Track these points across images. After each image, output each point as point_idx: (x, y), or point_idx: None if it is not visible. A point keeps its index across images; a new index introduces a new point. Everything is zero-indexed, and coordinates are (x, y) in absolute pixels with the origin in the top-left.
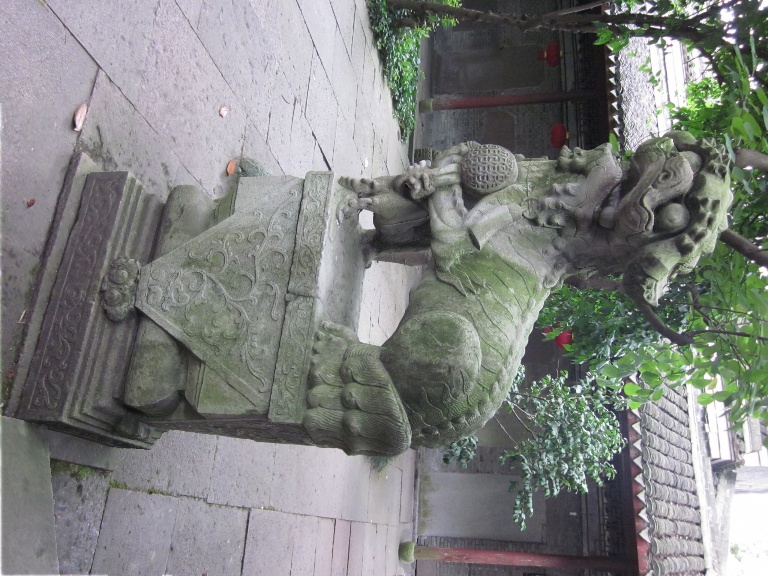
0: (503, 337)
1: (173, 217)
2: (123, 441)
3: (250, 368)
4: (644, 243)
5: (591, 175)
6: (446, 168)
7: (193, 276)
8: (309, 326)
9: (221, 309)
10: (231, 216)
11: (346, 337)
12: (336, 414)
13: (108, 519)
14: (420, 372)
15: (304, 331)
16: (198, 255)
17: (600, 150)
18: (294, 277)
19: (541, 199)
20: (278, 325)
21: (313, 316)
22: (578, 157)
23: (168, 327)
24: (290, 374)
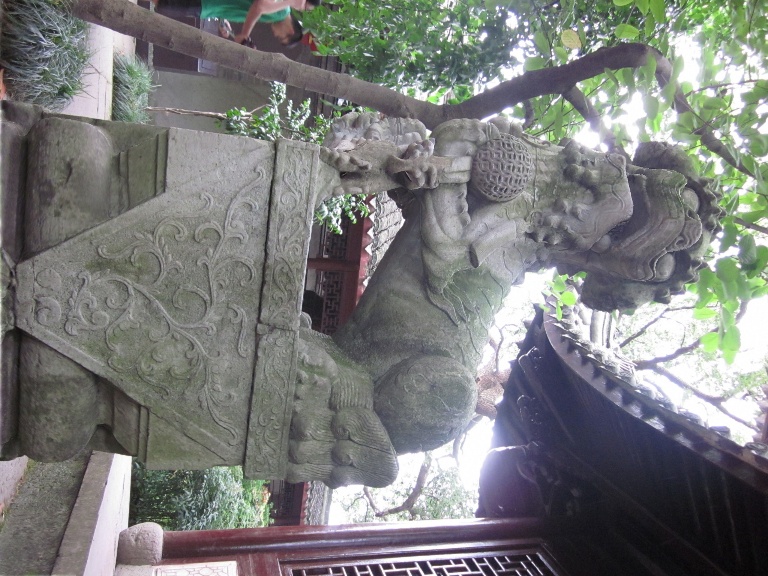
0: (479, 360)
1: (55, 179)
2: None
3: (215, 417)
4: (626, 281)
5: (606, 205)
6: (459, 163)
7: (110, 286)
8: (290, 368)
9: (163, 338)
10: (163, 196)
11: (329, 374)
12: (325, 468)
13: None
14: (422, 433)
15: (284, 374)
16: (114, 254)
17: (617, 169)
18: (268, 303)
19: (544, 211)
20: (248, 364)
21: (295, 356)
22: (591, 167)
23: (81, 359)
24: (269, 426)
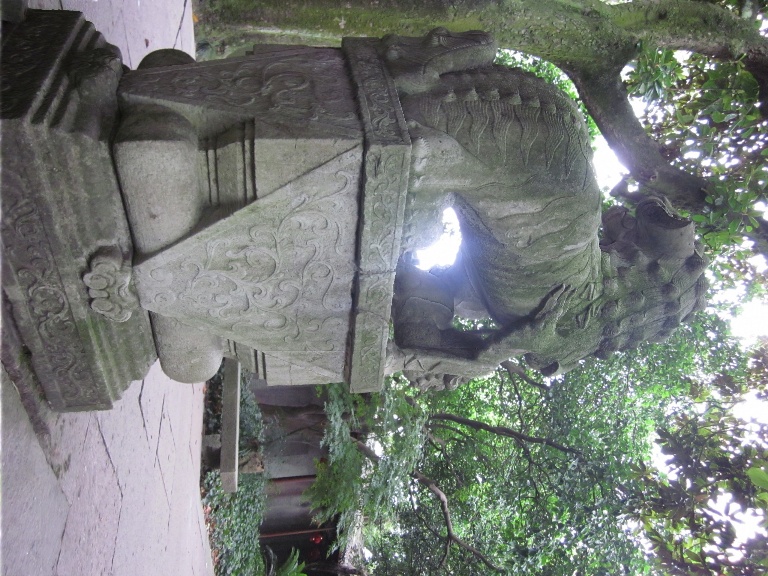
0: None
1: None
2: (49, 71)
3: None
4: None
5: None
6: None
7: None
8: None
9: None
10: None
11: None
12: None
13: None
14: None
15: None
16: None
17: None
18: None
19: None
20: None
21: None
22: None
23: None
24: None
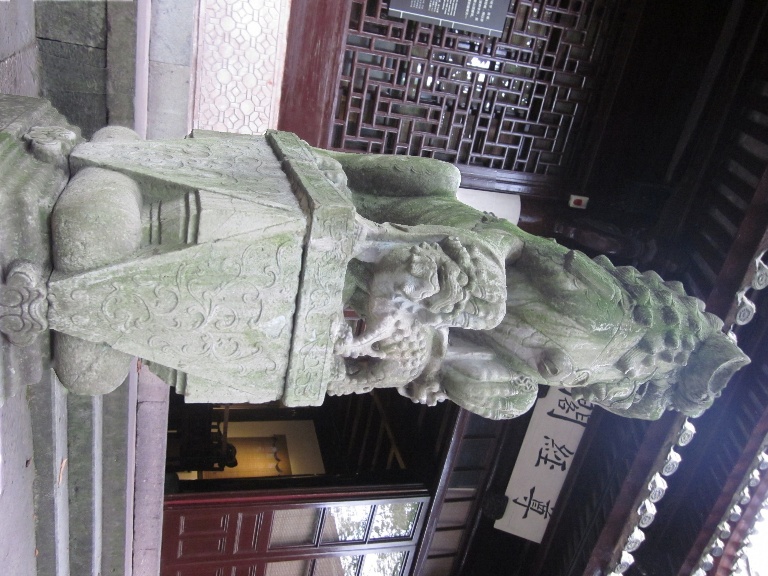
0: None
1: None
2: None
3: None
4: None
5: None
6: None
7: None
8: None
9: None
10: None
11: None
12: None
13: (1, 49)
14: None
15: None
16: None
17: None
18: None
19: None
20: None
21: None
22: None
23: None
24: None
